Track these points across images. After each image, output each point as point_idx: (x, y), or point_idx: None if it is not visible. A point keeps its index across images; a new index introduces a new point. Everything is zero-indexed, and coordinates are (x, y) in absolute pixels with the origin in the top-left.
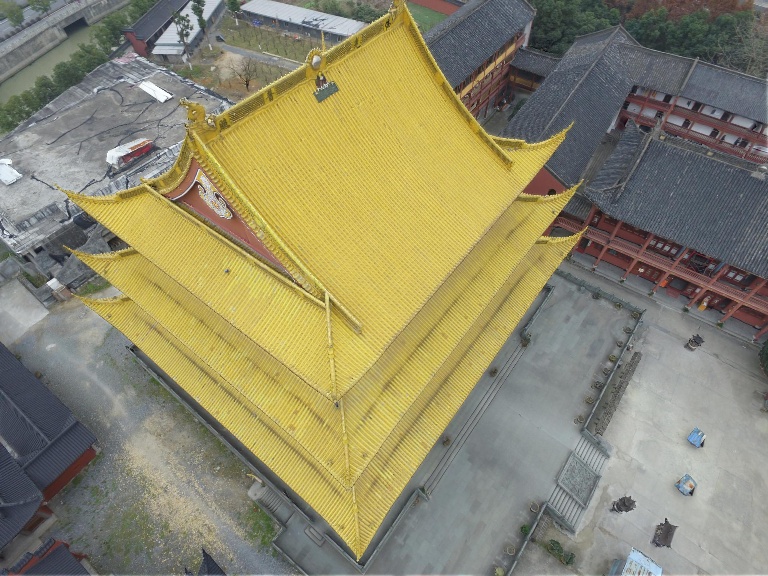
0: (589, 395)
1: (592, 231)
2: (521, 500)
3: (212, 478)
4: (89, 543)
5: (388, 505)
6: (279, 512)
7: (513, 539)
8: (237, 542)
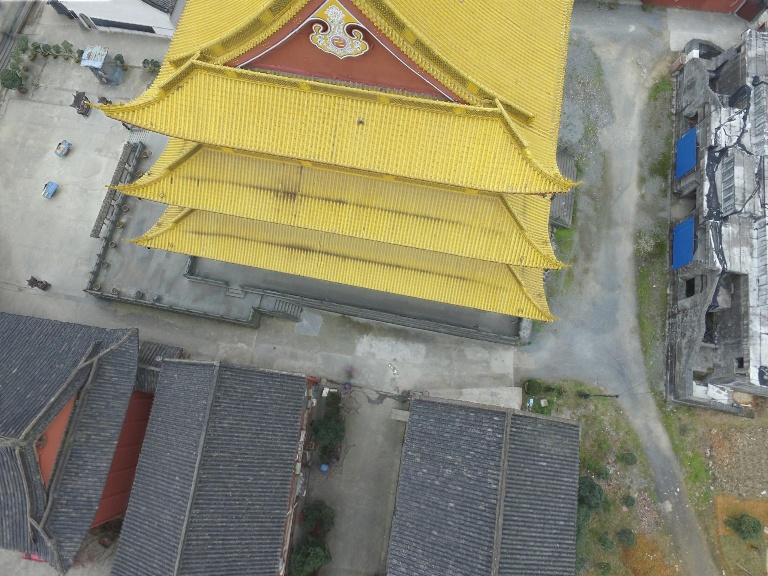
0: None
1: None
2: None
3: None
4: None
5: None
6: None
7: None
8: None
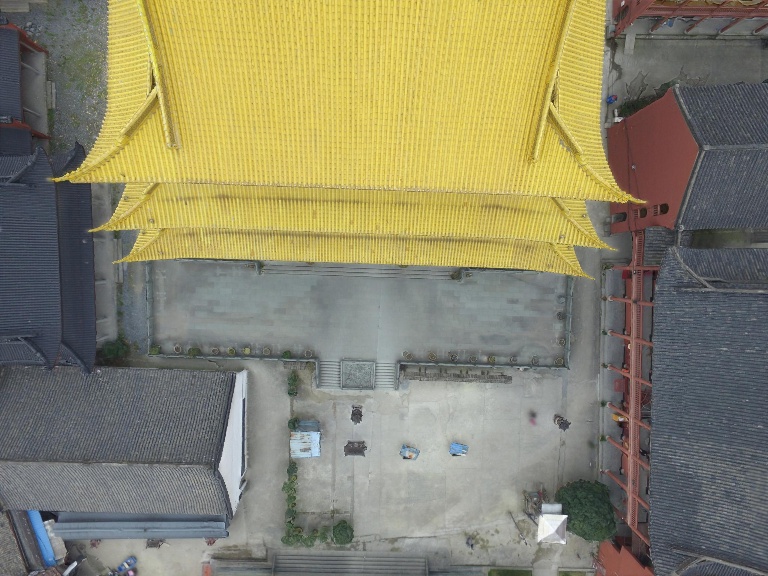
0: (439, 354)
1: (641, 278)
2: (309, 341)
3: None
4: (55, 45)
5: (188, 255)
6: None
7: (277, 349)
8: None
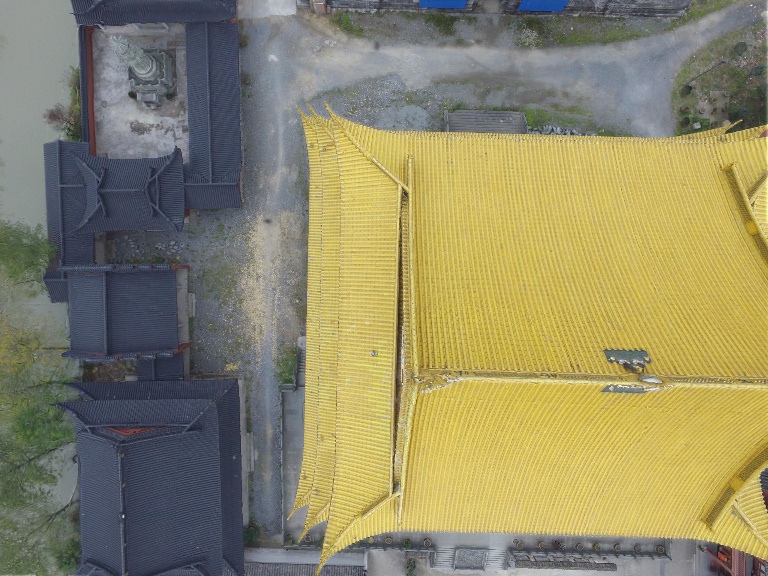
0: (547, 541)
1: None
2: None
3: (288, 303)
4: (195, 260)
5: None
6: (302, 376)
7: (397, 537)
8: (268, 357)
